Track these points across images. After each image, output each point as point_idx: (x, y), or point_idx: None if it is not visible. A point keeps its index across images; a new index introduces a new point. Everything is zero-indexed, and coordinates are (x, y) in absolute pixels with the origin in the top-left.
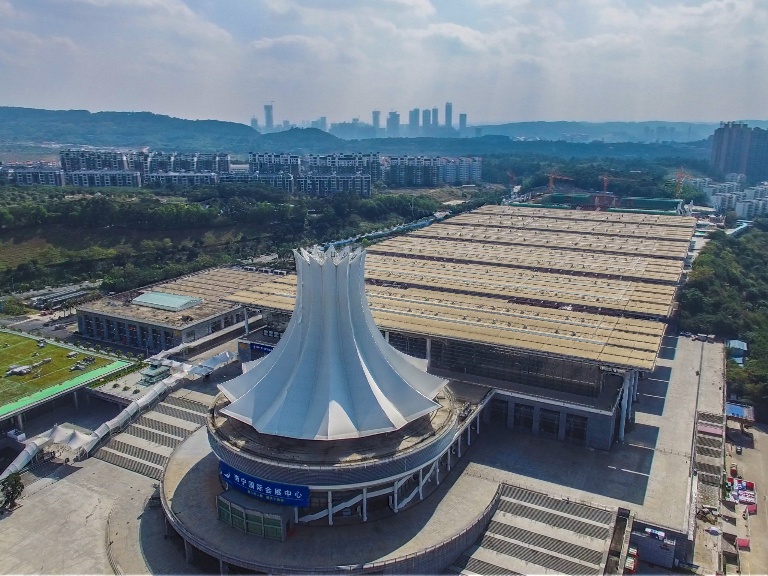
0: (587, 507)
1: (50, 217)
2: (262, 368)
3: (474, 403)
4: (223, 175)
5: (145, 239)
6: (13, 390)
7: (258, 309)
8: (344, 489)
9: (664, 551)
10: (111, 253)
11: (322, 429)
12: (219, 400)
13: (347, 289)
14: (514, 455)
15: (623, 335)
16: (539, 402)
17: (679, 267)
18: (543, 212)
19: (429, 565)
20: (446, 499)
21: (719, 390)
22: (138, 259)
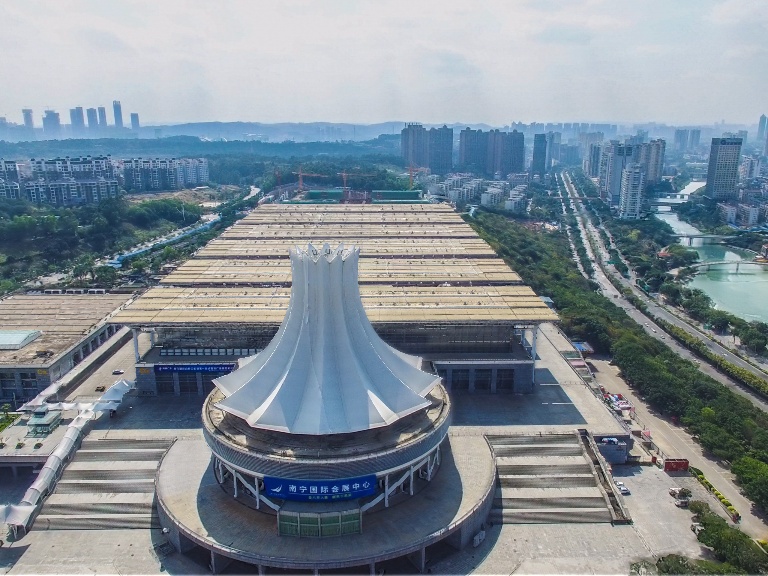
0: (557, 435)
1: None
2: (263, 377)
3: None
4: None
5: None
6: None
7: (153, 328)
8: (404, 468)
9: (619, 452)
10: None
11: (373, 417)
12: (214, 421)
13: None
14: (472, 412)
15: (513, 299)
16: (474, 365)
17: (485, 244)
18: (323, 207)
19: (483, 513)
20: (457, 459)
21: (559, 334)
22: None
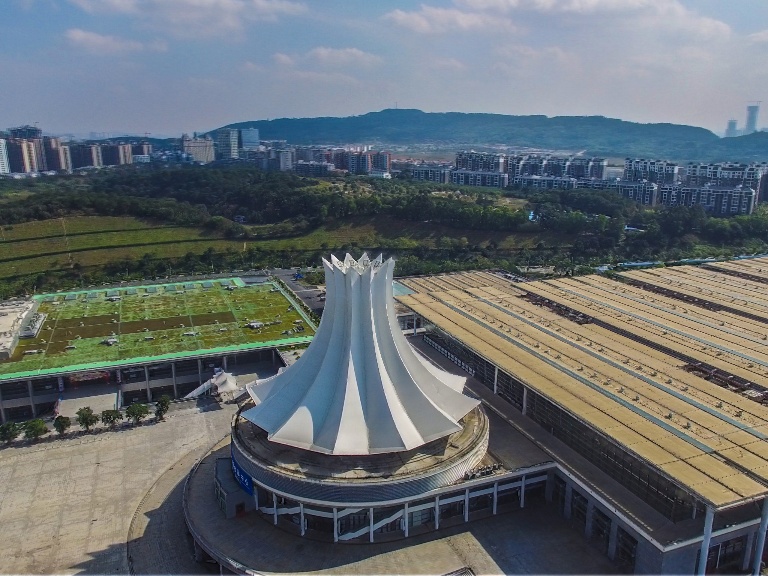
0: None
1: (383, 208)
2: None
3: (507, 467)
4: (581, 181)
5: (445, 236)
6: (234, 338)
7: None
8: (276, 493)
9: None
10: (413, 245)
11: (278, 429)
12: None
13: (353, 300)
14: (526, 546)
15: (767, 450)
16: (593, 497)
17: None
18: None
19: None
20: (392, 553)
21: None
22: (436, 253)
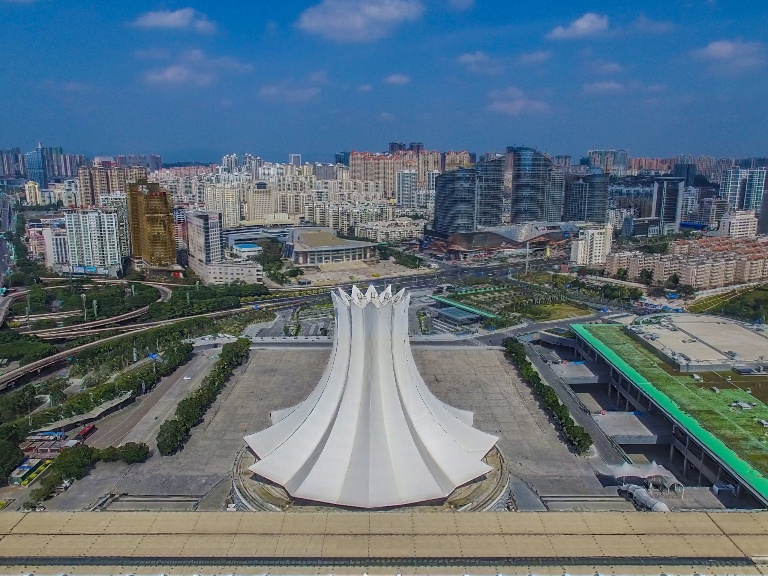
0: None
1: None
2: None
3: None
4: None
5: None
6: None
7: None
8: None
9: None
10: None
11: None
12: None
13: None
14: None
15: None
16: None
17: None
18: None
19: None
20: None
21: None
22: None
